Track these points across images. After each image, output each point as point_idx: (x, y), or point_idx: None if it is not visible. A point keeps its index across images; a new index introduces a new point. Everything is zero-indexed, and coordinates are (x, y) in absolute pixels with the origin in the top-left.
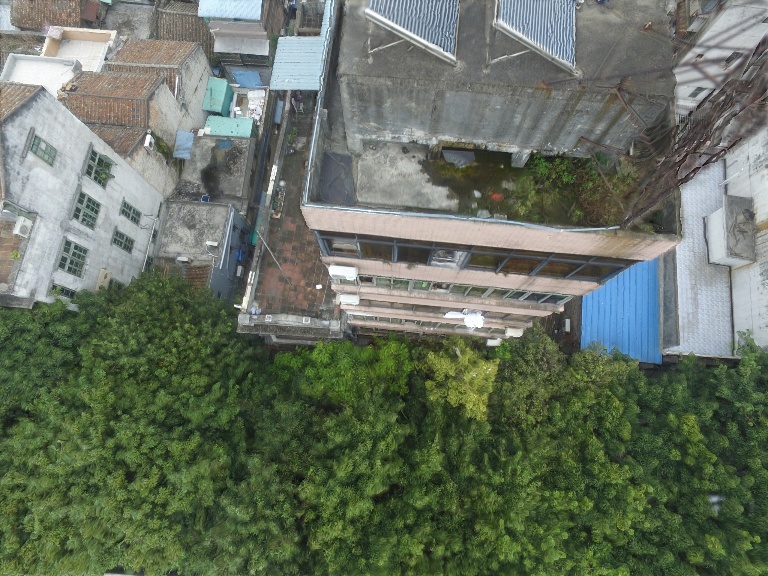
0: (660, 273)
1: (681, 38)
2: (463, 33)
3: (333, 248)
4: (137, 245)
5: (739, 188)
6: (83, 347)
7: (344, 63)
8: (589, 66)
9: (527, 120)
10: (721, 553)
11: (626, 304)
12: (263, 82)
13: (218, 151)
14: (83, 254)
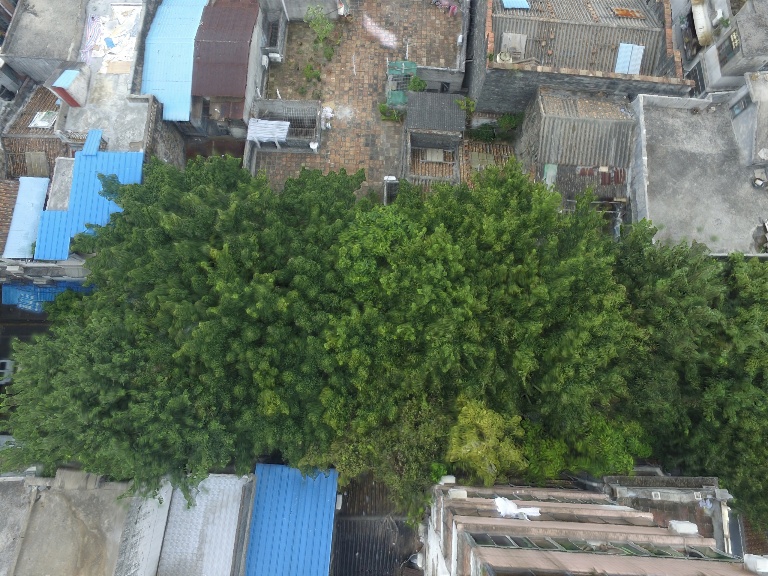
0: (242, 574)
1: None
2: None
3: None
4: None
5: None
6: None
7: None
8: None
9: None
10: None
11: (285, 532)
12: None
13: None
14: None
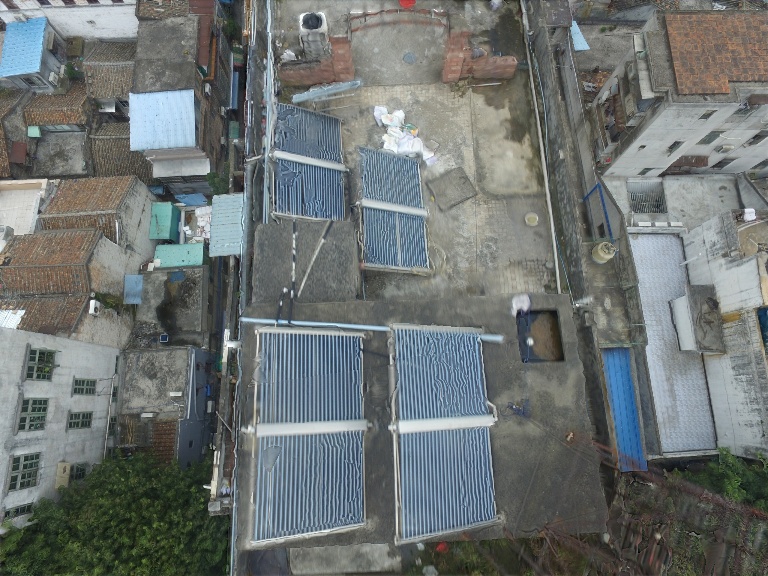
0: (633, 374)
1: None
2: (371, 474)
3: None
4: (96, 414)
5: (699, 271)
6: None
7: (243, 536)
8: (512, 503)
9: None
10: None
11: None
12: None
13: (171, 284)
14: (35, 460)
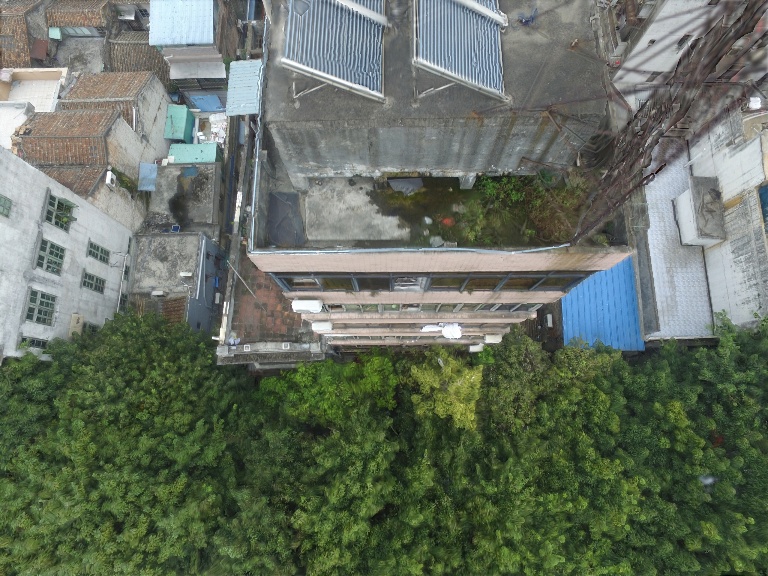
0: (635, 260)
1: (632, 25)
2: (389, 68)
3: (294, 283)
4: (109, 284)
5: (703, 168)
6: (59, 398)
7: (271, 110)
8: (519, 90)
9: (465, 147)
10: (717, 538)
11: (604, 294)
12: (224, 104)
13: (184, 179)
14: (51, 302)
